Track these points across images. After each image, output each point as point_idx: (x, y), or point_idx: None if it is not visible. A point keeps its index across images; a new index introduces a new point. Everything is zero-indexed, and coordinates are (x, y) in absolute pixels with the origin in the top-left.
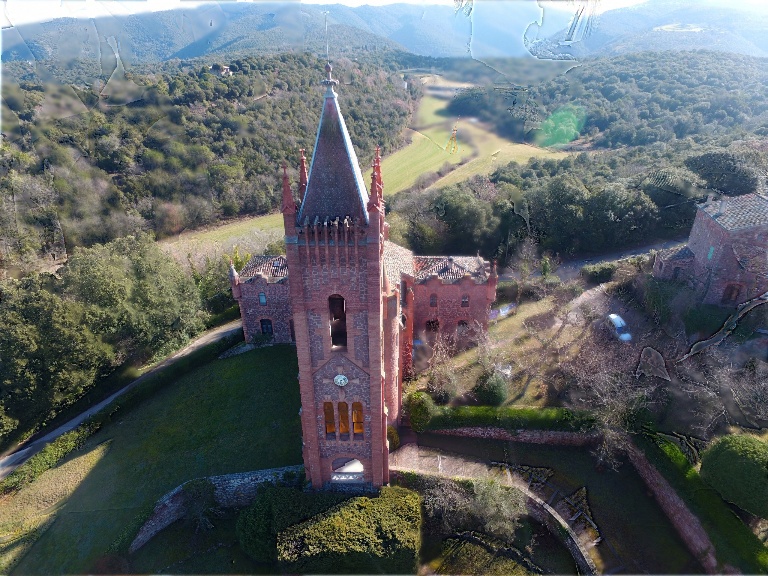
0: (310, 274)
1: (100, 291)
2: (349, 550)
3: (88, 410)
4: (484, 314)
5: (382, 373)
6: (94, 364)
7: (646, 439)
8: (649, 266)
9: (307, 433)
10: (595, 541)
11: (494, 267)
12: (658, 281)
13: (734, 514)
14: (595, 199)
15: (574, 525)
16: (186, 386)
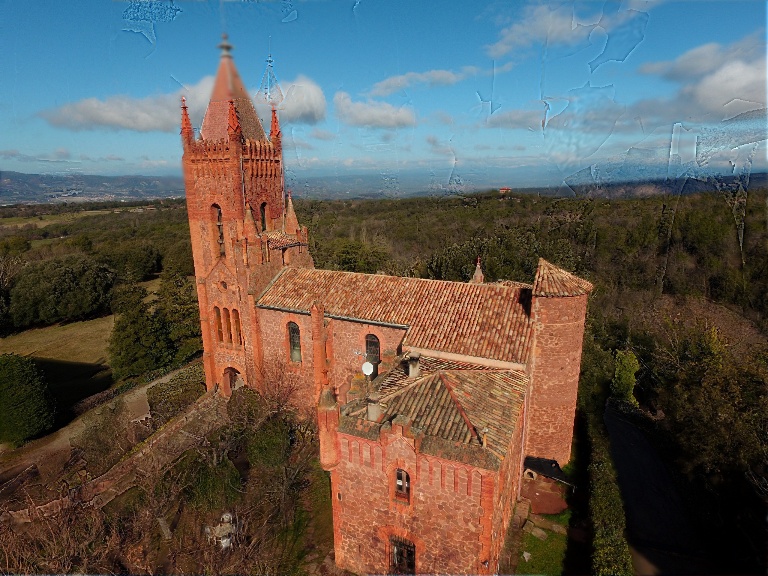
0: None
1: None
2: None
3: None
4: None
5: (200, 278)
6: None
7: None
8: None
9: None
10: None
11: None
12: None
13: None
14: None
15: None
16: None
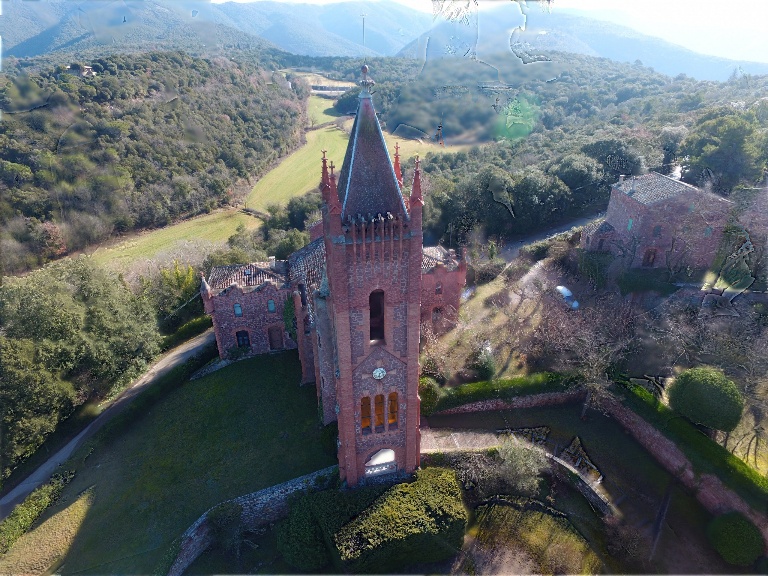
0: (354, 272)
1: (51, 323)
2: (408, 534)
3: (48, 460)
4: (456, 299)
5: None
6: (55, 406)
7: (617, 386)
8: (573, 242)
9: (345, 432)
10: (599, 479)
11: None
12: (589, 253)
13: (701, 432)
14: (520, 186)
15: (579, 470)
16: (164, 414)
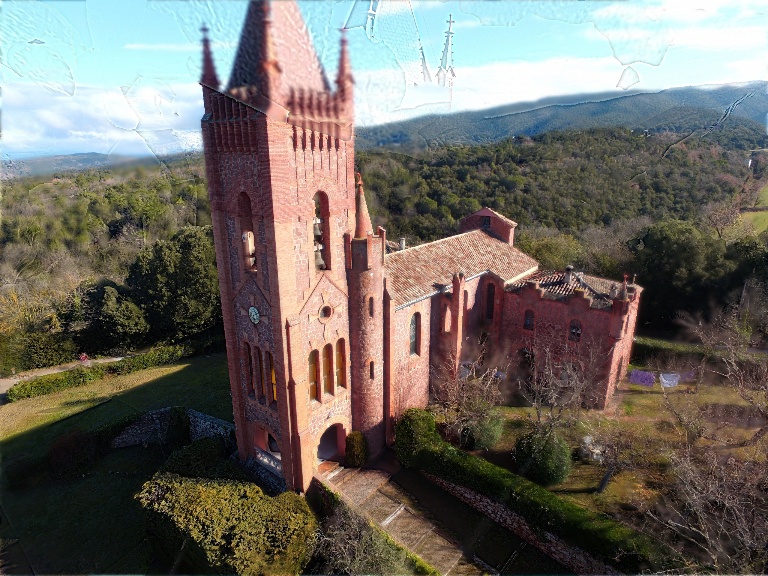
0: (224, 164)
1: None
2: (186, 529)
3: None
4: (604, 360)
5: (291, 317)
6: (212, 301)
7: None
8: None
9: None
10: None
11: (623, 284)
12: None
13: None
14: None
15: None
16: None
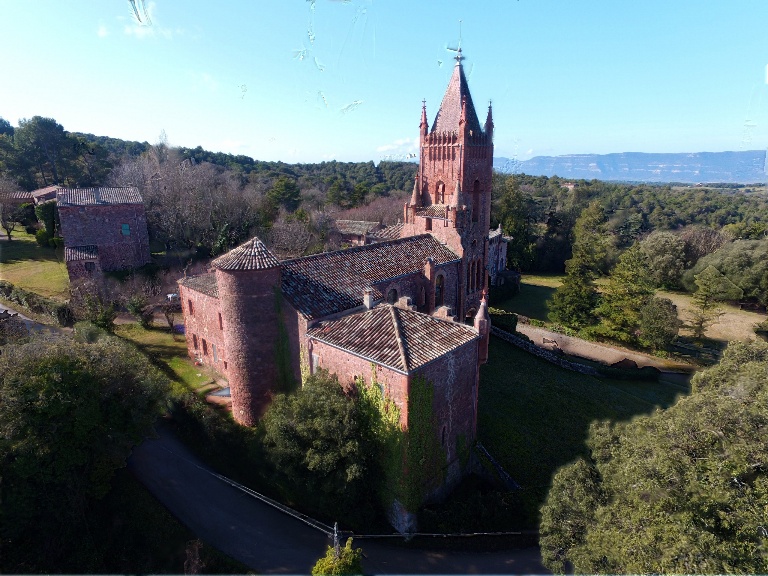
0: None
1: None
2: None
3: None
4: None
5: None
6: None
7: None
8: None
9: None
10: None
11: None
12: None
13: None
14: None
15: None
16: None
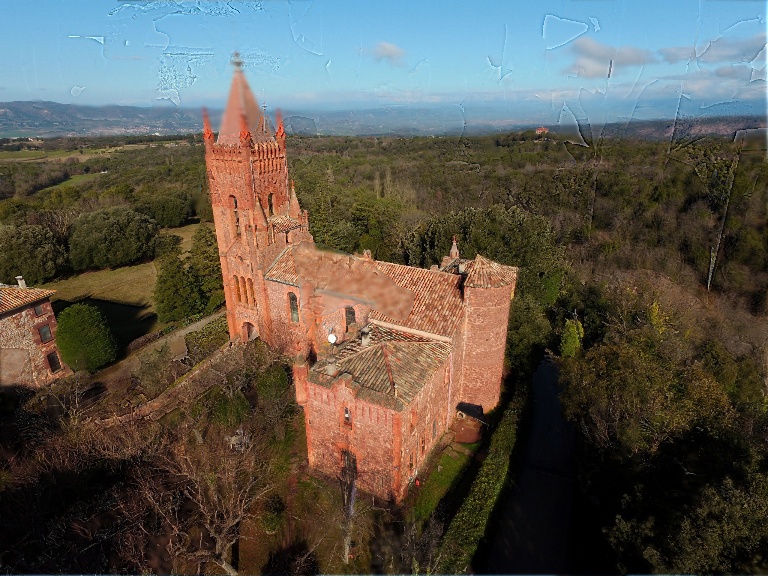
0: None
1: None
2: None
3: None
4: None
5: (222, 252)
6: None
7: None
8: None
9: None
10: None
11: None
12: None
13: None
14: None
15: None
16: None
